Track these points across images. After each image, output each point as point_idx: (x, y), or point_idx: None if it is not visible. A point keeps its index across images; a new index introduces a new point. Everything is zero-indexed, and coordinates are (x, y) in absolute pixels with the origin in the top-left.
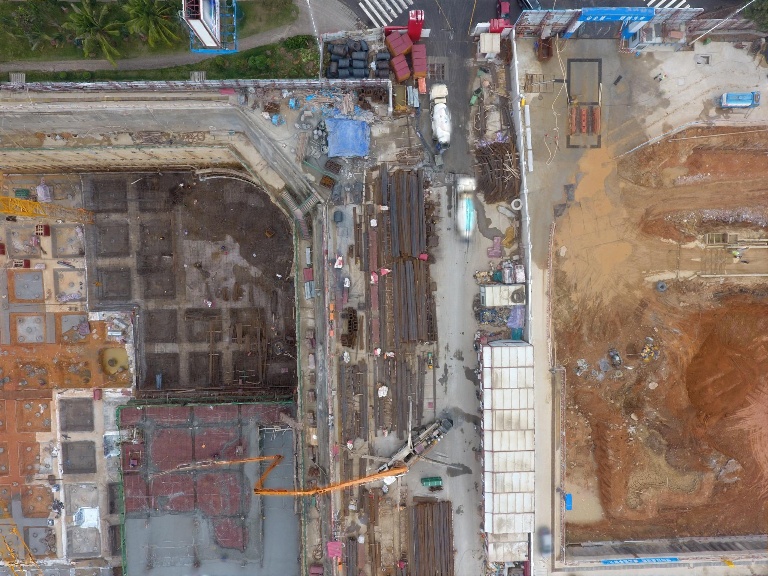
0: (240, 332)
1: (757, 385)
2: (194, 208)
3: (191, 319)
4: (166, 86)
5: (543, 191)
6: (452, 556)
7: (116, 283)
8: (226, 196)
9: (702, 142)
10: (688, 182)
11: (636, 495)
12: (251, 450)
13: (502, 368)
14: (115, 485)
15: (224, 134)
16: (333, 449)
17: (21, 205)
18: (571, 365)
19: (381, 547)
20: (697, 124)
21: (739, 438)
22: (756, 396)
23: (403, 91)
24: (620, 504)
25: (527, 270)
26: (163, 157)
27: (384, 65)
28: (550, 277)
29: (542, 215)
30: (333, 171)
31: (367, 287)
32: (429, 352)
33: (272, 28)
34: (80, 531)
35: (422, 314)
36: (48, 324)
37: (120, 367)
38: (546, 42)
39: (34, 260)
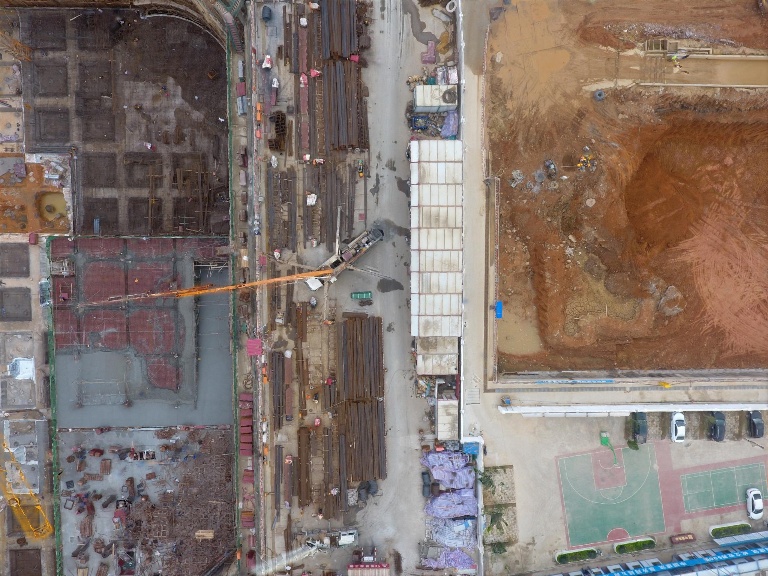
0: (181, 177)
1: (701, 215)
2: (135, 47)
3: (130, 162)
4: None
5: None
6: (382, 375)
7: (54, 125)
8: (168, 36)
9: None
10: None
11: (574, 322)
12: (186, 286)
13: (430, 162)
14: (51, 335)
15: None
16: (260, 259)
17: None
18: (506, 176)
19: (309, 363)
20: None
21: (682, 270)
22: (699, 227)
23: None
24: (557, 329)
25: (460, 72)
26: None
27: None
28: (484, 80)
29: (477, 18)
30: None
31: (297, 91)
32: (360, 160)
33: None
34: (15, 382)
35: (352, 118)
36: None
37: (58, 213)
38: None
39: None
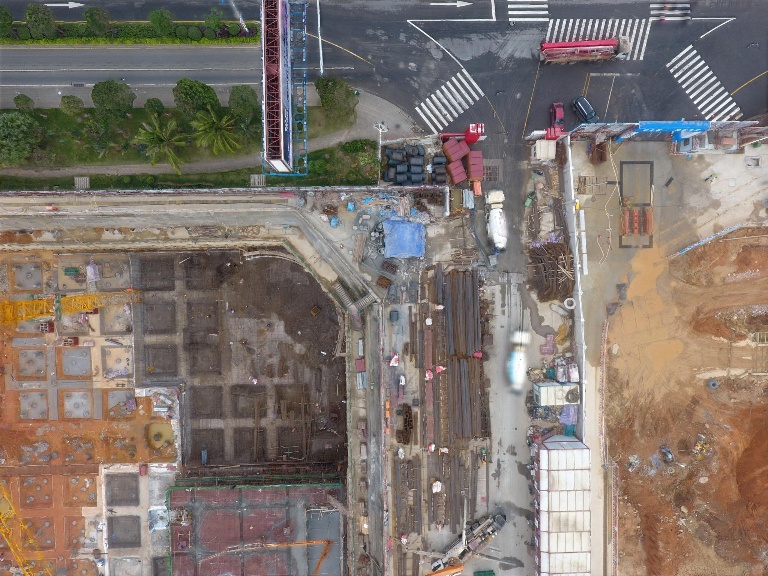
0: (285, 409)
1: None
2: (240, 287)
3: (236, 396)
4: (228, 191)
5: (596, 290)
6: None
7: (162, 359)
8: (272, 274)
9: (752, 242)
10: (738, 279)
11: None
12: (298, 531)
13: (559, 471)
14: (159, 559)
15: (279, 228)
16: (387, 543)
17: (82, 302)
18: (623, 461)
19: None
20: (748, 225)
21: None
22: None
23: (459, 195)
24: None
25: (581, 369)
26: (215, 245)
27: (442, 171)
28: (603, 376)
29: (595, 314)
30: (390, 272)
31: (421, 383)
32: (482, 448)
33: (331, 132)
34: None
35: (476, 411)
36: (95, 400)
37: (165, 442)
38: (599, 146)
39: (82, 337)
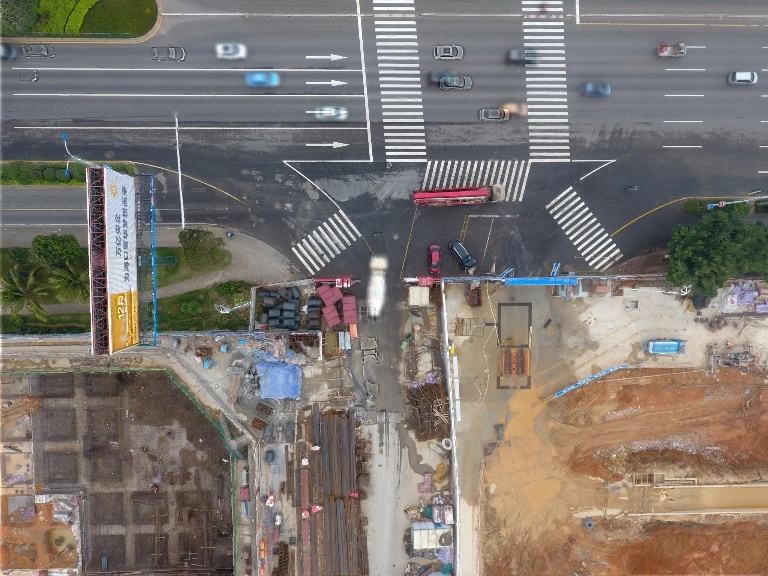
0: (186, 516)
1: None
2: (141, 394)
3: (137, 503)
4: None
5: (473, 431)
6: None
7: (63, 465)
8: (173, 382)
9: (631, 383)
10: (618, 416)
11: None
12: None
13: None
14: None
15: (162, 357)
16: None
17: None
18: None
19: None
20: None
21: None
22: None
23: (334, 338)
24: None
25: (456, 511)
26: None
27: (314, 316)
28: (479, 517)
29: (472, 454)
30: (265, 413)
31: (299, 521)
32: None
33: (205, 273)
34: None
35: (352, 551)
36: None
37: (67, 546)
38: (476, 288)
39: None
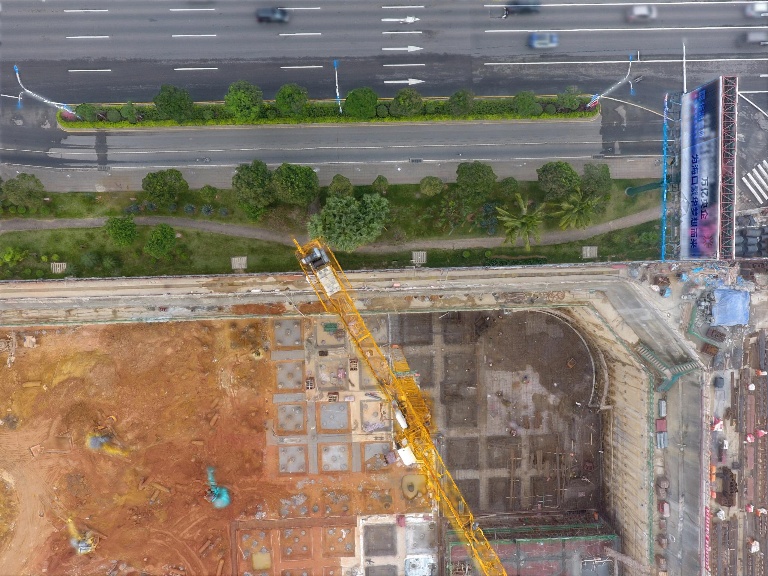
0: (540, 459)
1: None
2: (498, 340)
3: (493, 447)
4: None
5: None
6: None
7: None
8: (527, 327)
9: None
10: None
11: None
12: None
13: None
14: None
15: (584, 293)
16: None
17: None
18: None
19: None
20: None
21: None
22: None
23: None
24: None
25: None
26: None
27: None
28: None
29: None
30: (717, 340)
31: (740, 447)
32: None
33: (661, 204)
34: None
35: None
36: (354, 453)
37: (419, 492)
38: None
39: (342, 392)
